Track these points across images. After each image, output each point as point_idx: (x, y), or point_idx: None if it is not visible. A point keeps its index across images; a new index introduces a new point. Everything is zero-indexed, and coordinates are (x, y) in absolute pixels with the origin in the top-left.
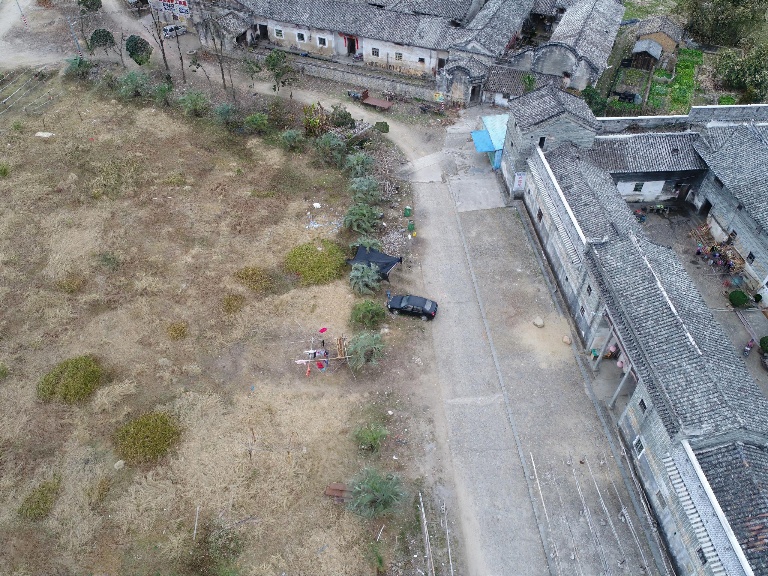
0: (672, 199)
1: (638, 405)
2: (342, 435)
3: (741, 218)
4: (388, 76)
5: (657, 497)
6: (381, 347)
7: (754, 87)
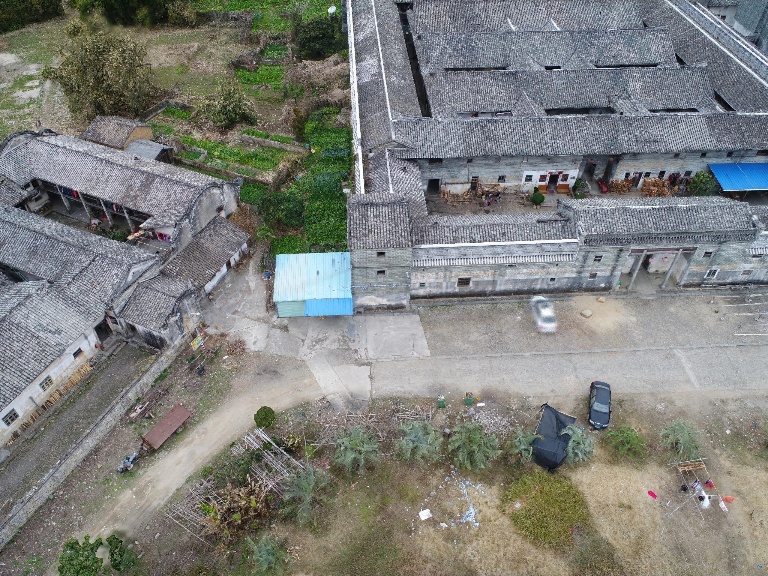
0: None
1: (702, 258)
2: None
3: (476, 166)
4: (67, 414)
5: (742, 275)
6: None
7: None
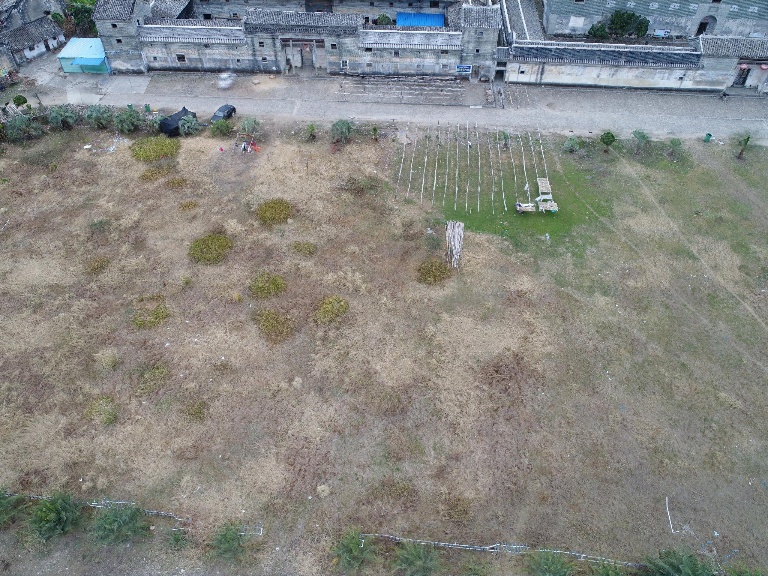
0: None
1: (331, 49)
2: (301, 147)
3: (232, 4)
4: None
5: (367, 67)
6: None
7: None
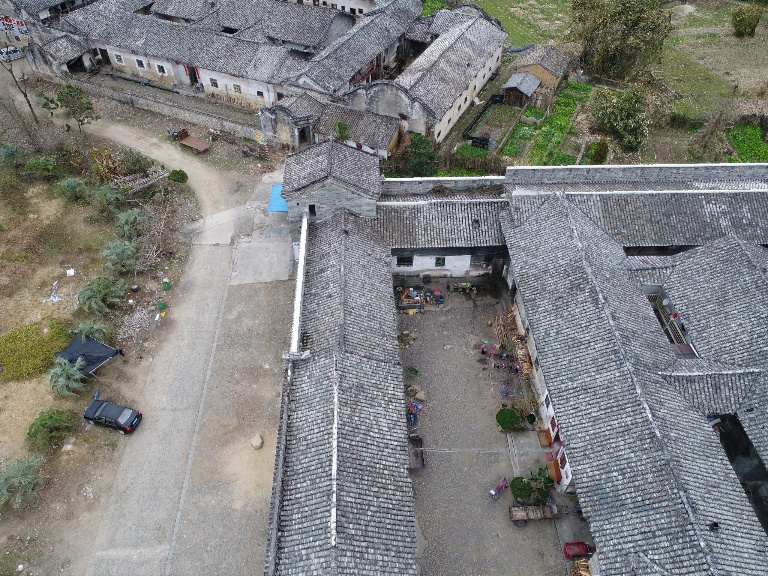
0: (486, 275)
1: None
2: None
3: None
4: (226, 110)
5: None
6: (29, 479)
7: (628, 133)
